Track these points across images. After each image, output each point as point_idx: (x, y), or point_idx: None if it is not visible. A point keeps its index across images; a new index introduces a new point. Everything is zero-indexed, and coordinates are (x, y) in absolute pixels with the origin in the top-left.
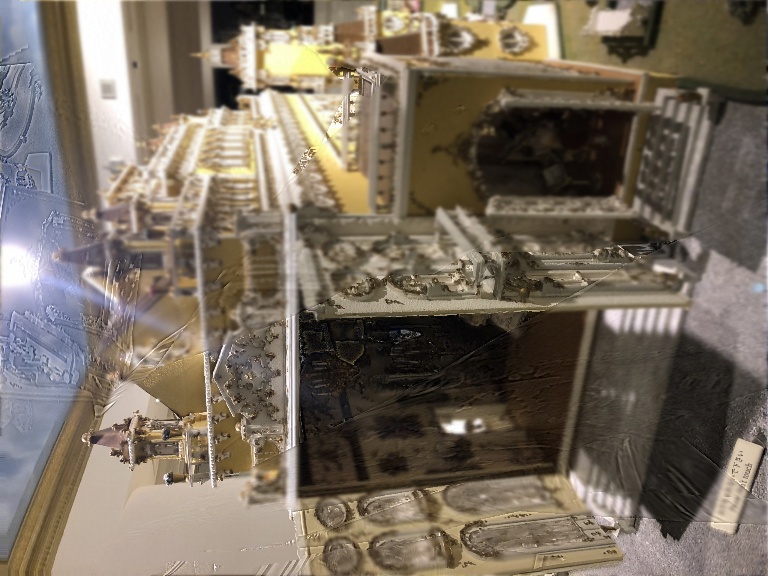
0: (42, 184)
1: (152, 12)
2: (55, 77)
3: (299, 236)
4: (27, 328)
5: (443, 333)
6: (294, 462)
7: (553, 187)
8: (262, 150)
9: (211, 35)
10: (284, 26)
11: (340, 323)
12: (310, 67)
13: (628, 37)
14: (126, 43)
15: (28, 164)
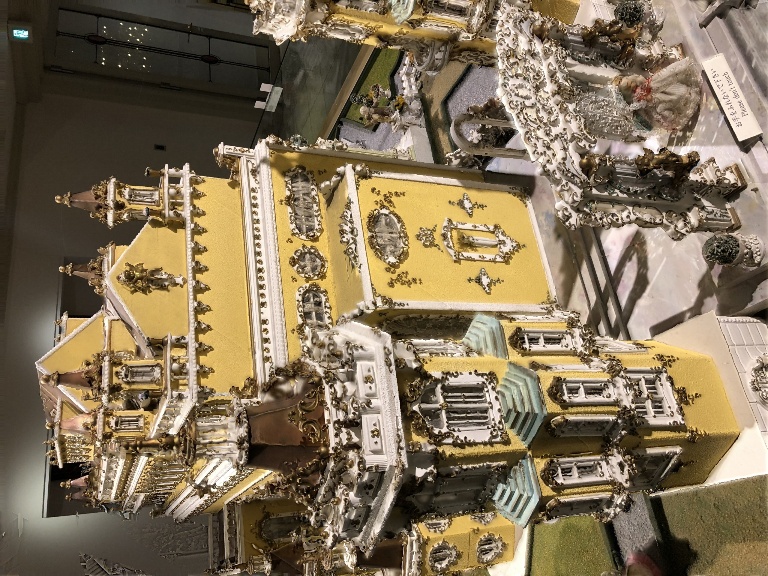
0: None
1: None
2: None
3: None
4: None
5: None
6: (146, 545)
7: None
8: None
9: None
10: None
11: None
12: None
13: None
14: None
15: None
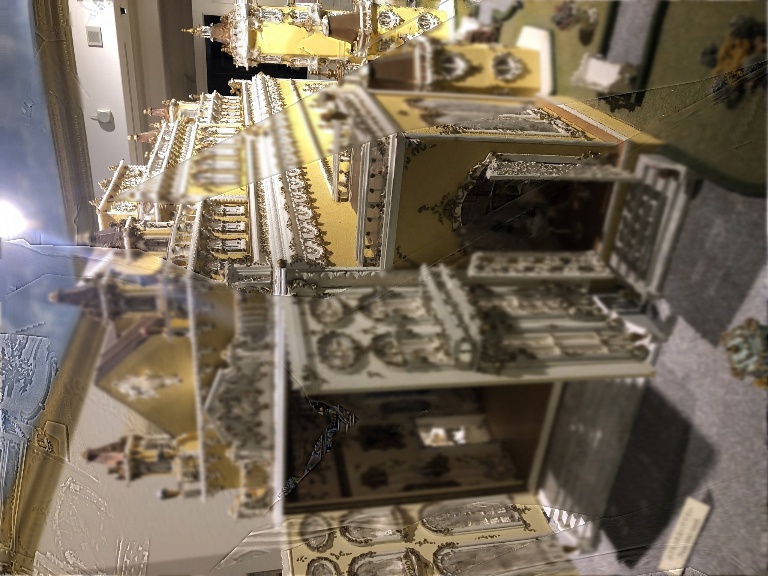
0: (59, 451)
1: (155, 312)
2: (69, 358)
3: (283, 516)
4: (48, 567)
5: None
6: None
7: (502, 474)
8: (252, 470)
9: (208, 347)
10: (272, 353)
11: None
12: (294, 397)
13: (569, 375)
14: (132, 338)
15: (46, 430)
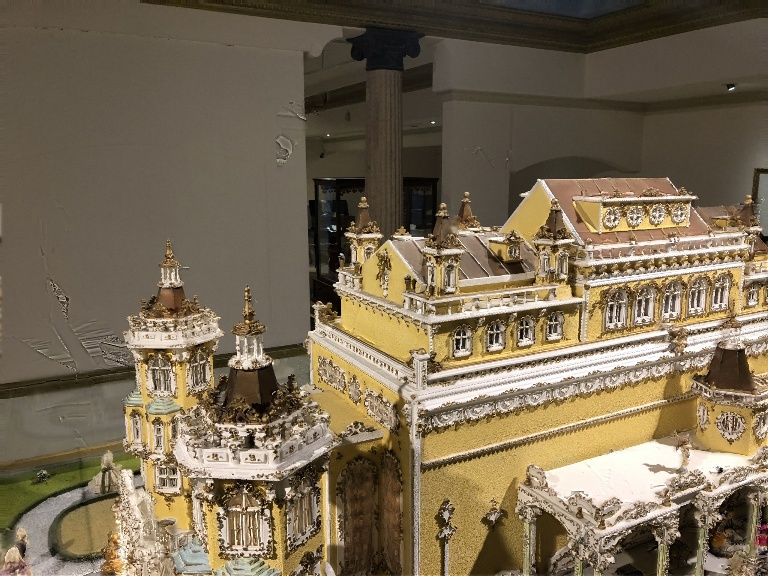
0: None
1: None
2: None
3: None
4: None
5: (680, 520)
6: None
7: None
8: None
9: None
10: None
11: (667, 419)
12: None
13: None
14: None
15: None
